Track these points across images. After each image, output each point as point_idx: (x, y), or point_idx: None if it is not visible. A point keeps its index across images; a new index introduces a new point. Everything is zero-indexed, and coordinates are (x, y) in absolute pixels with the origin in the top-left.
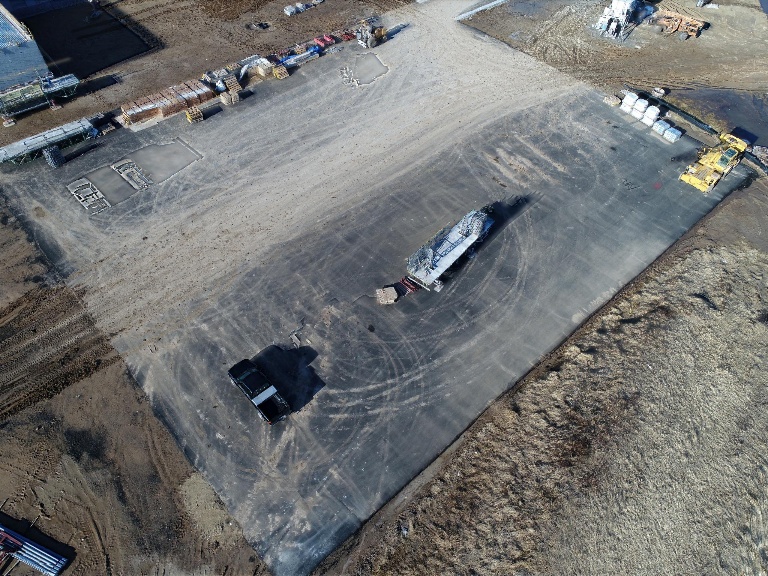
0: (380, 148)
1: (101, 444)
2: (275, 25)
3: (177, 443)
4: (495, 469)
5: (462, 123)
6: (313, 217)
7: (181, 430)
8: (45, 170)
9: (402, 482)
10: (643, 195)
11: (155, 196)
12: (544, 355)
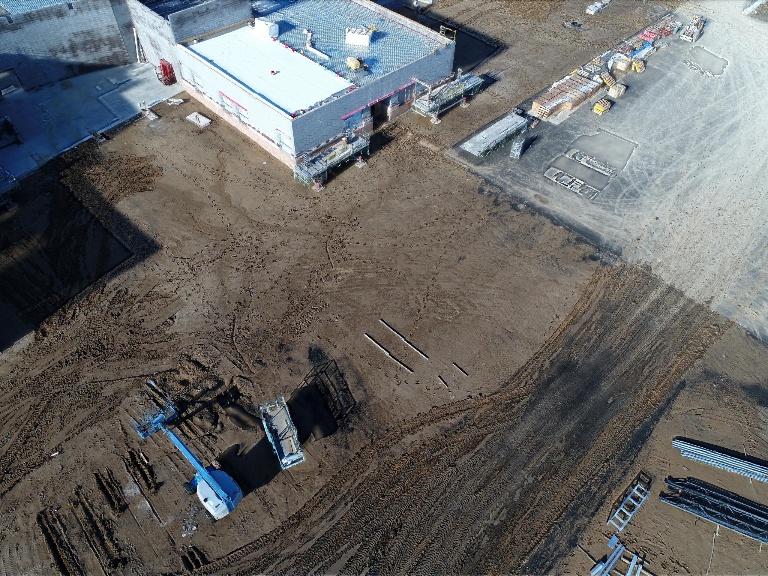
0: None
1: None
2: (586, 24)
3: None
4: None
5: None
6: None
7: None
8: (511, 161)
9: None
10: None
11: (630, 181)
12: None
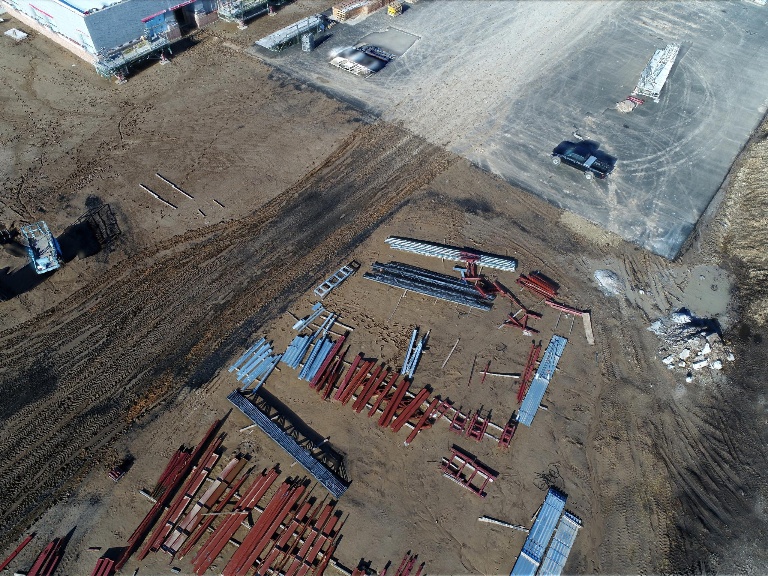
0: (554, 22)
1: (486, 205)
2: None
3: (540, 198)
4: (767, 185)
5: (603, 3)
6: (536, 67)
7: (537, 191)
8: (303, 54)
9: (705, 203)
10: (762, 37)
11: (405, 64)
12: (753, 131)
